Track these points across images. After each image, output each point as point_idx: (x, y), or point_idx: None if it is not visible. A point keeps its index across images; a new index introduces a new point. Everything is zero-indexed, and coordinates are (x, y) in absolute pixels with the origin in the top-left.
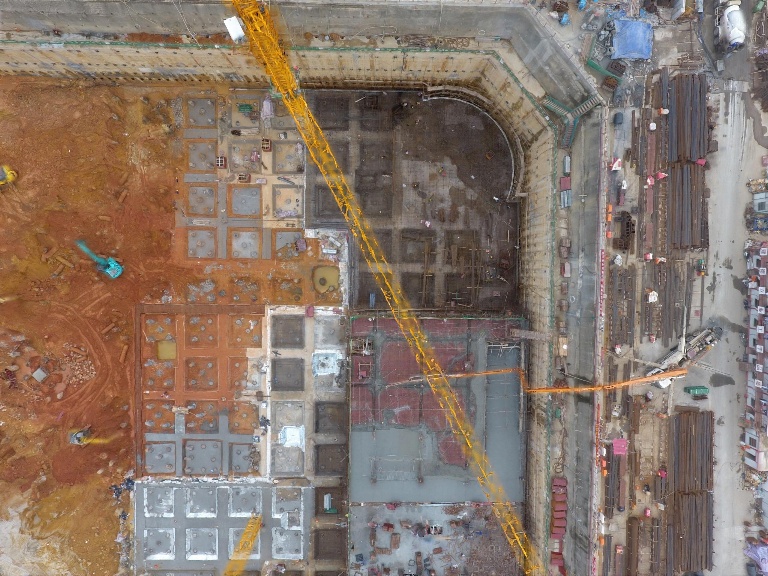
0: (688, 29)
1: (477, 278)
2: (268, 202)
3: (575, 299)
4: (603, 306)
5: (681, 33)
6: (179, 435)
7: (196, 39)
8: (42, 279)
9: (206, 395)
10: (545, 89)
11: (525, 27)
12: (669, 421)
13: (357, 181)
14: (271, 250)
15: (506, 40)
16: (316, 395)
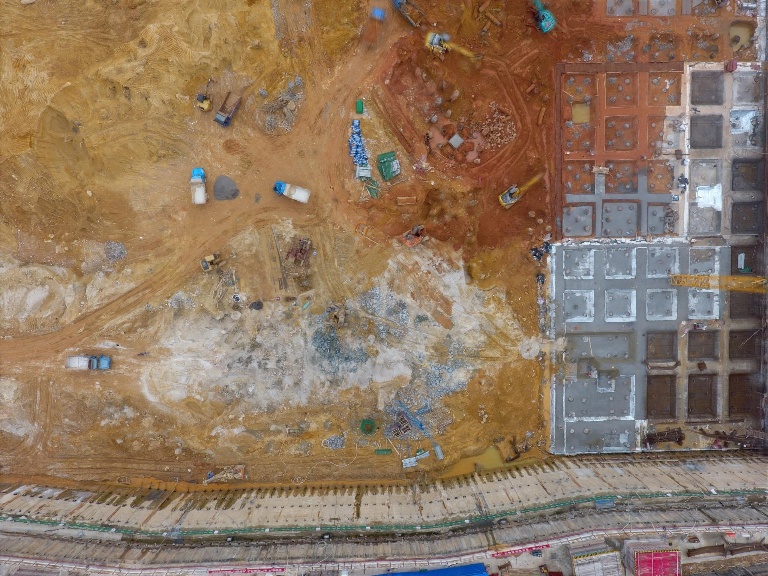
0: None
1: None
2: None
3: None
4: None
5: None
6: (599, 196)
7: None
8: (469, 38)
9: (625, 155)
10: None
11: None
12: None
13: None
14: (691, 5)
15: None
16: (734, 152)
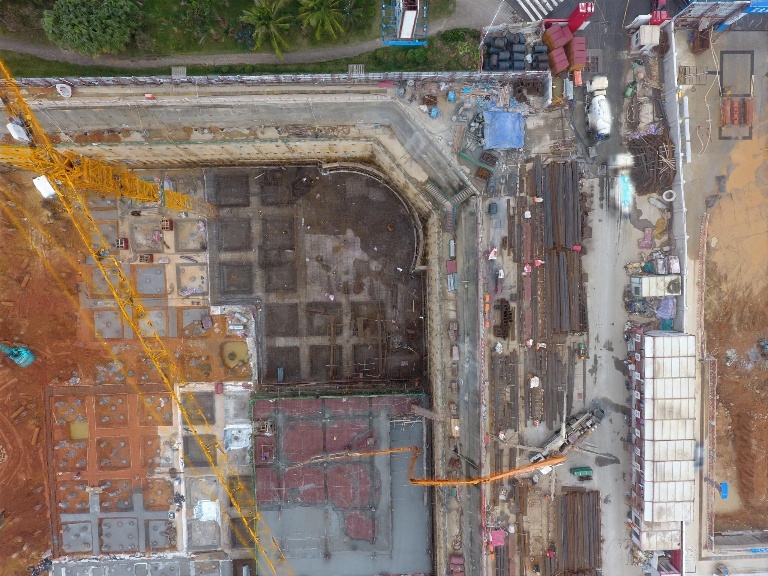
0: (559, 117)
1: (384, 348)
2: (172, 281)
3: (463, 383)
4: (487, 392)
5: (552, 121)
6: (94, 514)
7: (74, 137)
8: None
9: (119, 474)
10: (428, 174)
11: (399, 118)
12: (557, 502)
13: (260, 257)
14: (177, 328)
15: (386, 126)
16: (229, 470)
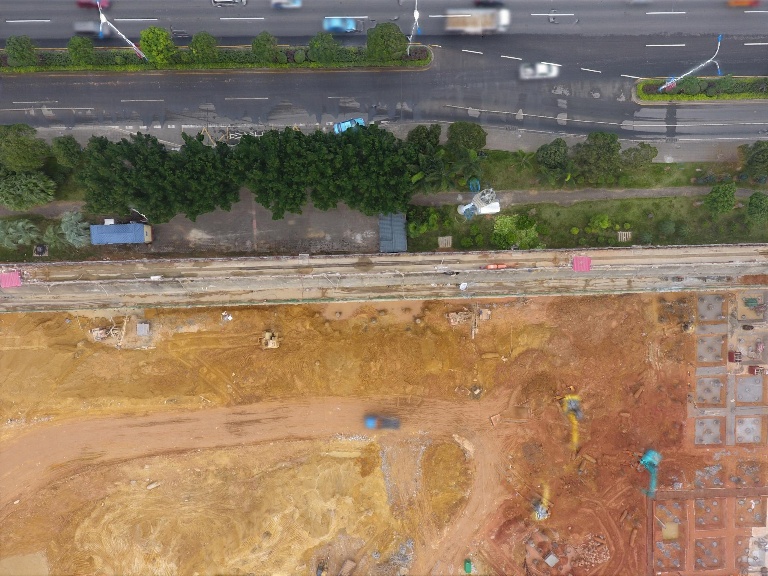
0: None
1: None
2: None
3: None
4: None
5: None
6: None
7: None
8: (566, 474)
9: (714, 573)
10: None
11: None
12: None
13: None
14: None
15: None
16: None
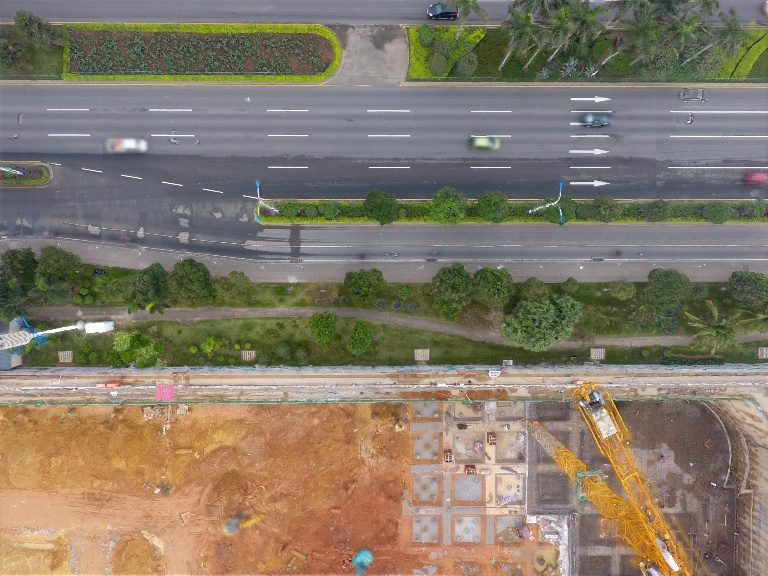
0: None
1: (695, 560)
2: (491, 490)
3: None
4: None
5: None
6: None
7: (464, 391)
8: (275, 570)
9: None
10: None
11: None
12: None
13: None
14: (494, 536)
15: None
16: None
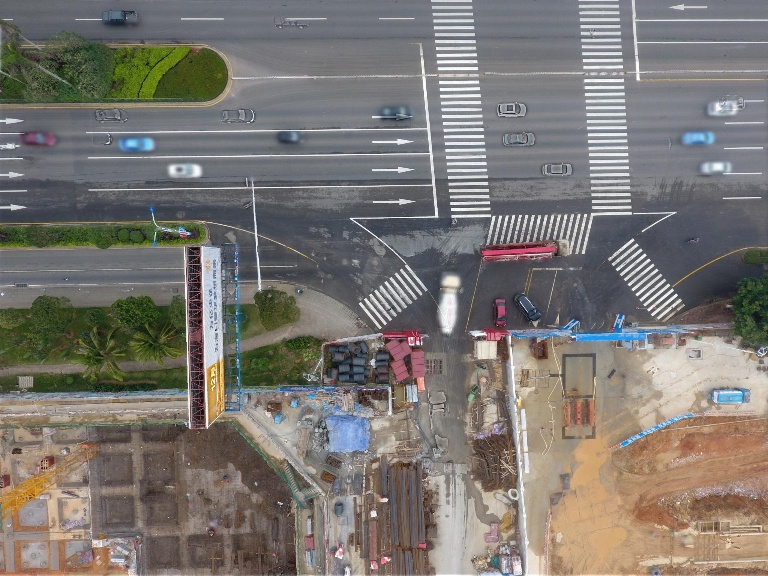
0: (404, 418)
1: None
2: (54, 515)
3: None
4: None
5: (397, 422)
6: None
7: None
8: None
9: None
10: None
11: None
12: None
13: (142, 491)
14: (59, 561)
15: None
16: None
